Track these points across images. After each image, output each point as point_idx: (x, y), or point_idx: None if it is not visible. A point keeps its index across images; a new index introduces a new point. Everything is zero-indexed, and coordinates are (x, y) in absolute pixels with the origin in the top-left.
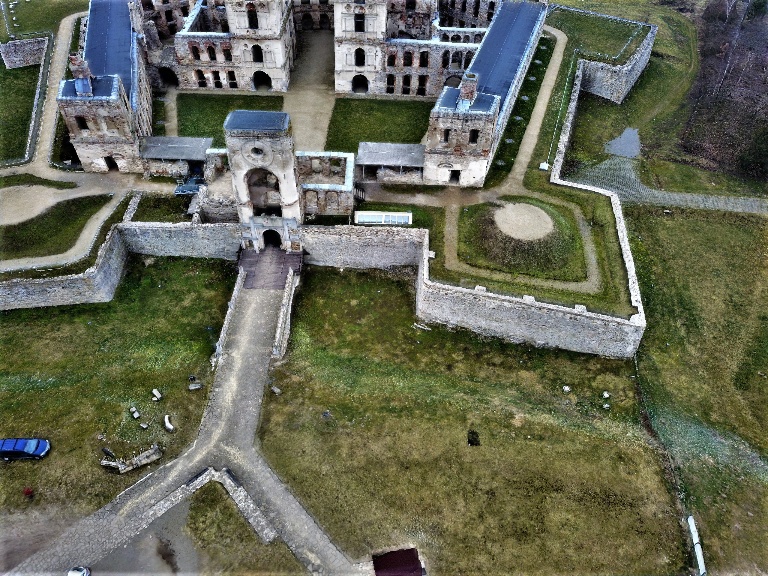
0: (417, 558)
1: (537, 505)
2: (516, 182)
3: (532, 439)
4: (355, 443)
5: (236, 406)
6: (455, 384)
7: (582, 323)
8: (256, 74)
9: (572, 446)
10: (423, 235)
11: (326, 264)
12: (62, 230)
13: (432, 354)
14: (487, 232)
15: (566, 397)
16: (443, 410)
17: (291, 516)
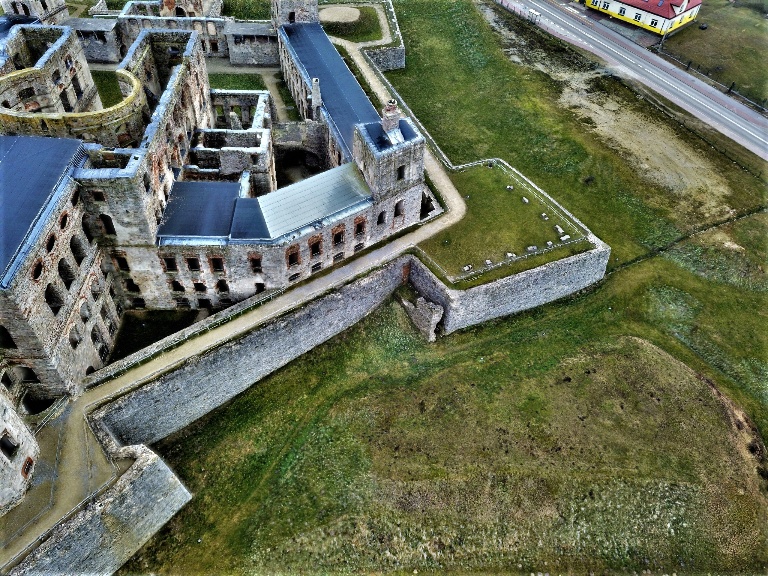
0: None
1: None
2: None
3: None
4: None
5: None
6: (108, 5)
7: None
8: None
9: None
10: None
11: None
12: None
13: None
14: None
15: None
16: None
17: None
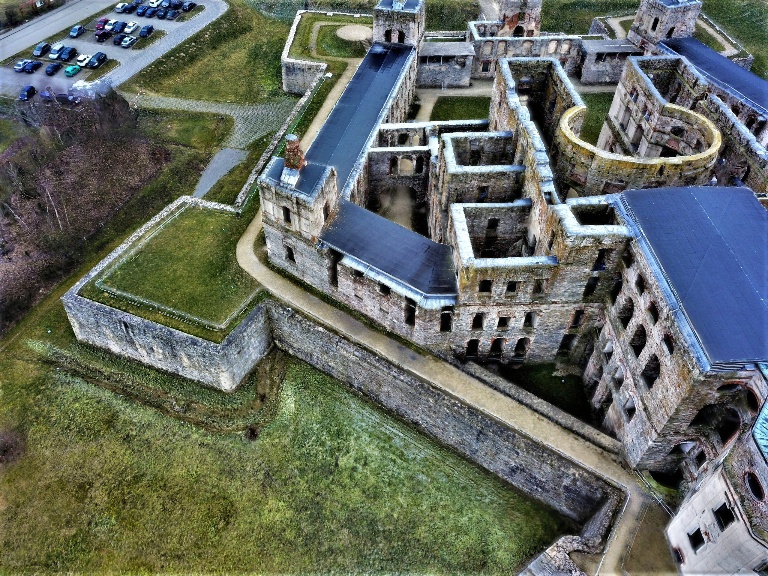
0: None
1: None
2: (353, 65)
3: None
4: None
5: (490, 2)
6: None
7: None
8: None
9: None
10: None
11: None
12: None
13: None
14: None
15: None
16: None
17: None
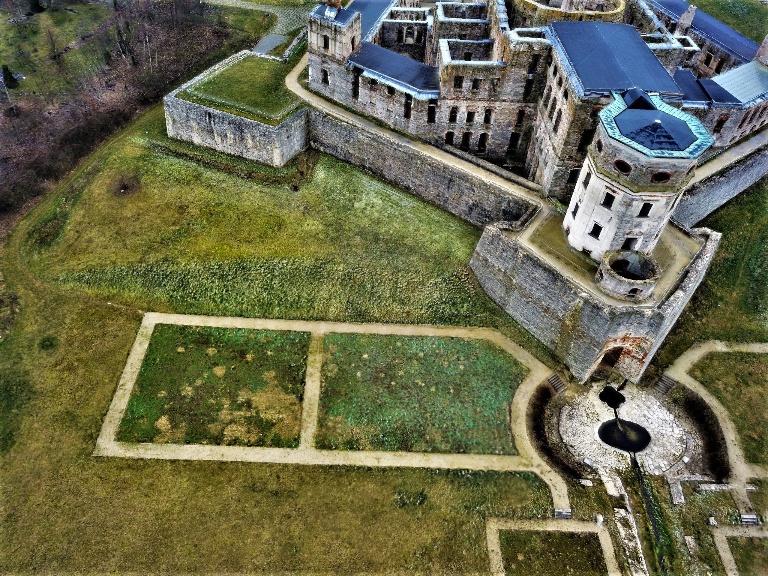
0: None
1: None
2: None
3: None
4: None
5: None
6: None
7: None
8: None
9: None
10: None
11: None
12: None
13: None
14: None
15: None
16: None
17: None
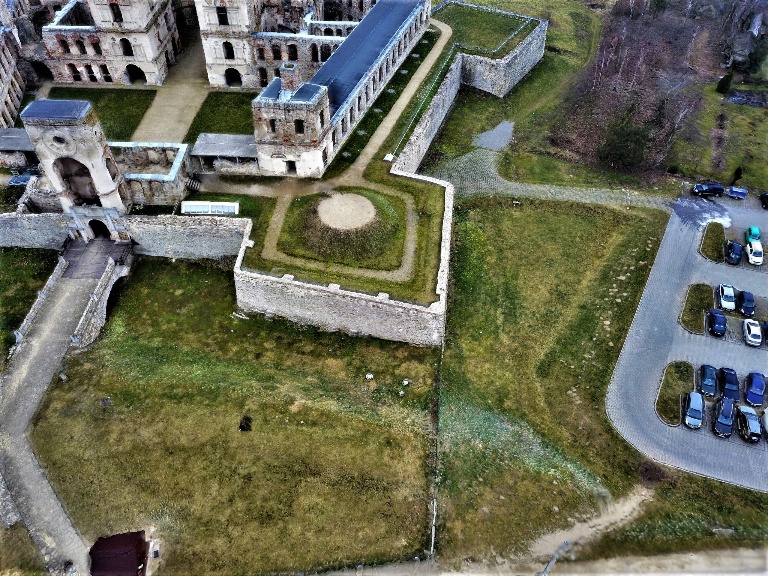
0: (138, 540)
1: (290, 489)
2: (356, 173)
3: (304, 424)
4: (126, 429)
5: (20, 393)
6: (256, 372)
7: (385, 311)
8: (129, 68)
9: (343, 431)
10: (246, 225)
11: (158, 254)
12: None
13: (244, 343)
14: (308, 222)
15: (366, 384)
16: (224, 396)
17: (40, 500)
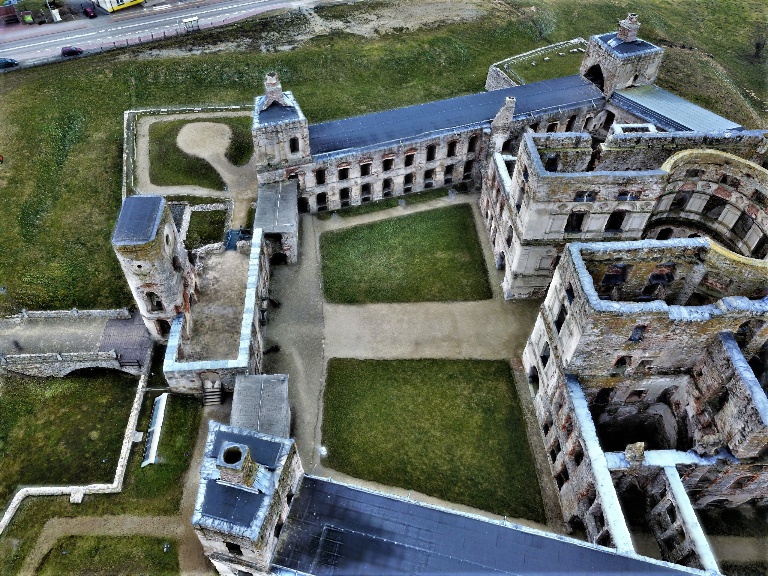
0: None
1: None
2: None
3: None
4: None
5: None
6: None
7: None
8: None
9: None
10: None
11: None
12: (179, 174)
13: None
14: (89, 575)
15: None
16: None
17: None
